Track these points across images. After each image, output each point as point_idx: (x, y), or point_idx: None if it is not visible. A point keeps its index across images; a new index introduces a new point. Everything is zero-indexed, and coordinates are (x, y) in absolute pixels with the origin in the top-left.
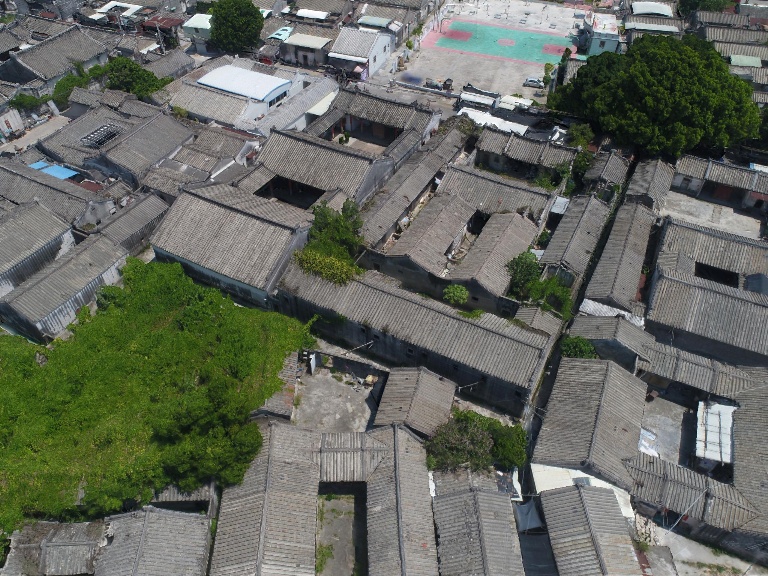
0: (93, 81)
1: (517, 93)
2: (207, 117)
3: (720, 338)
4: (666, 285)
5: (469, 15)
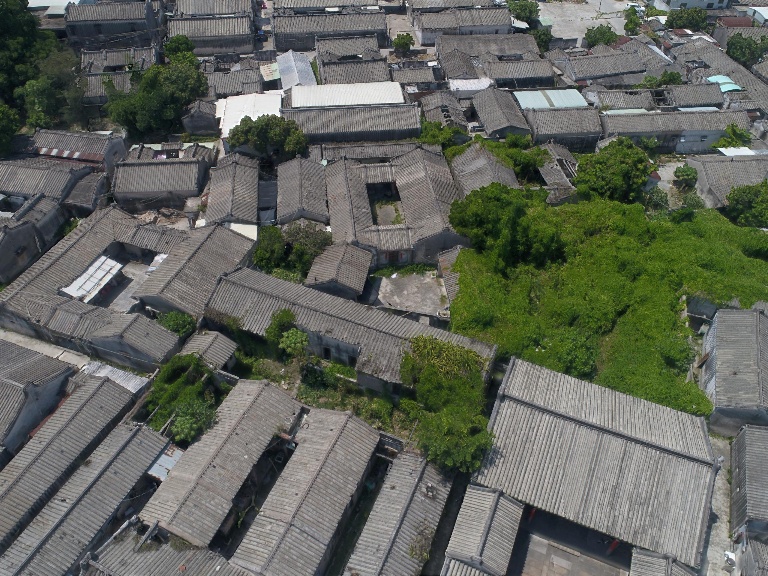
0: None
1: None
2: None
3: (16, 346)
4: None
5: None
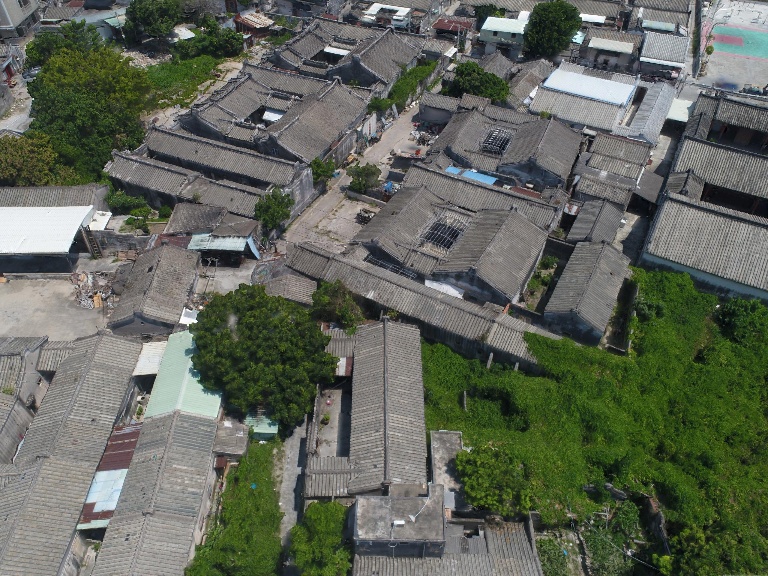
0: (418, 84)
1: None
2: (577, 122)
3: None
4: None
5: (723, 19)
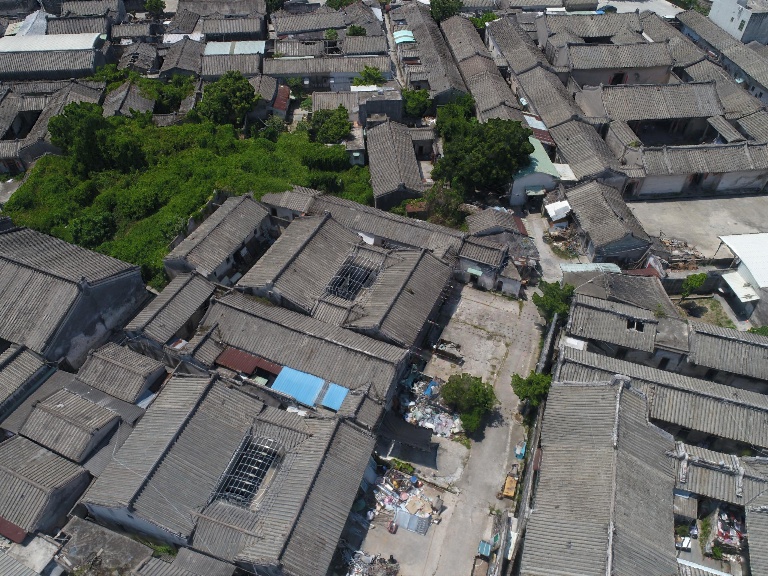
0: None
1: None
2: None
3: None
4: None
5: None
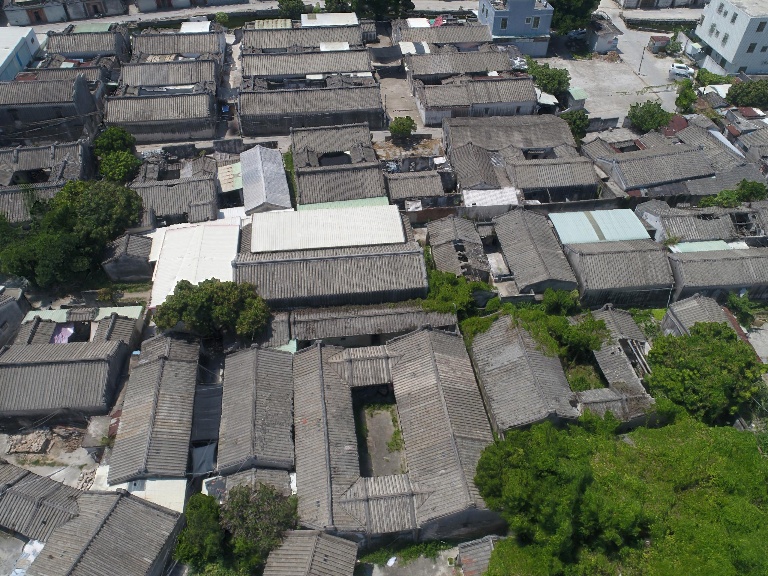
0: None
1: None
2: None
3: None
4: None
5: None
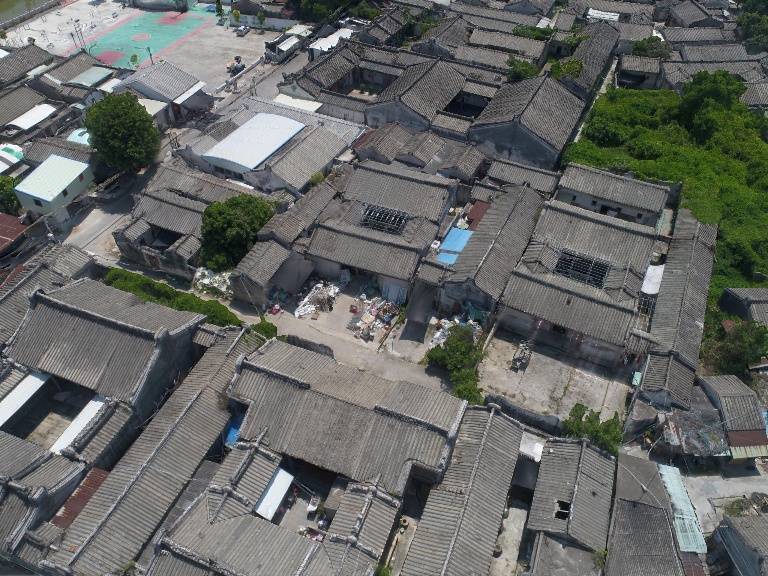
0: None
1: (255, 40)
2: (329, 161)
3: (552, 3)
4: (530, 1)
5: (51, 49)
